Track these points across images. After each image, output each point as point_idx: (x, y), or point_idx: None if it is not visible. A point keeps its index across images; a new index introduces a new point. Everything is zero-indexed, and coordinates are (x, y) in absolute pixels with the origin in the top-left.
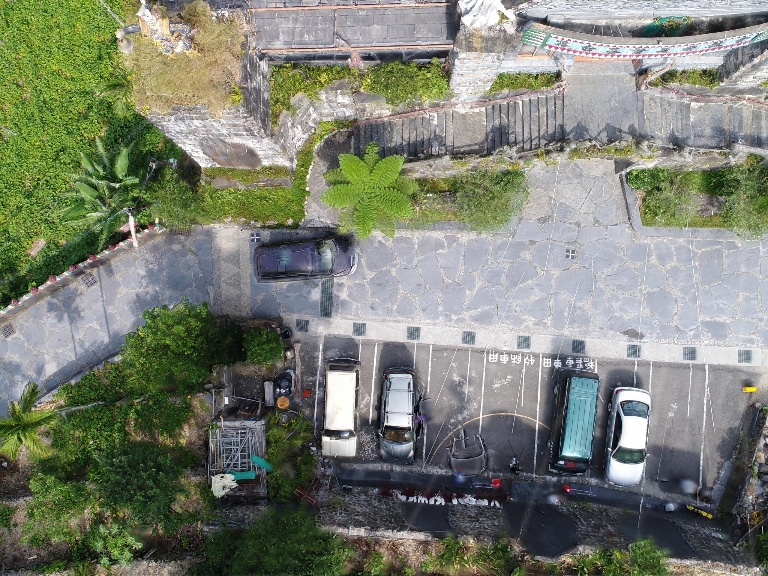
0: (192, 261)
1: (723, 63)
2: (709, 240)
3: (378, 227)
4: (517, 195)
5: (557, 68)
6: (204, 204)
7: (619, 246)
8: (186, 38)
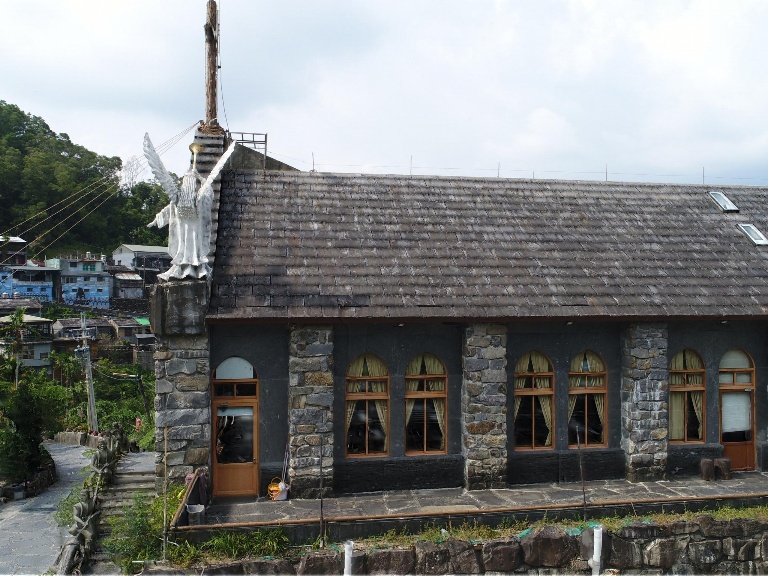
0: None
1: None
2: None
3: None
4: None
5: None
6: None
7: None
8: None
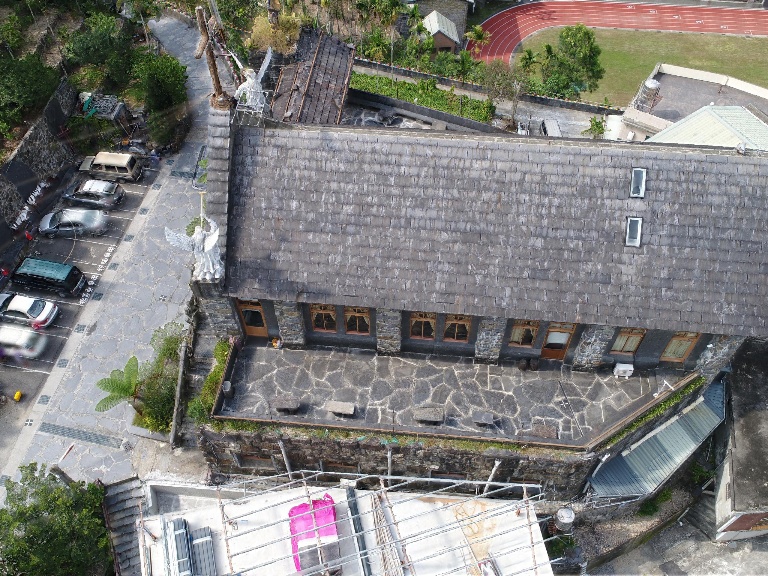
0: None
1: None
2: None
3: None
4: None
5: None
6: None
7: None
8: (272, 16)
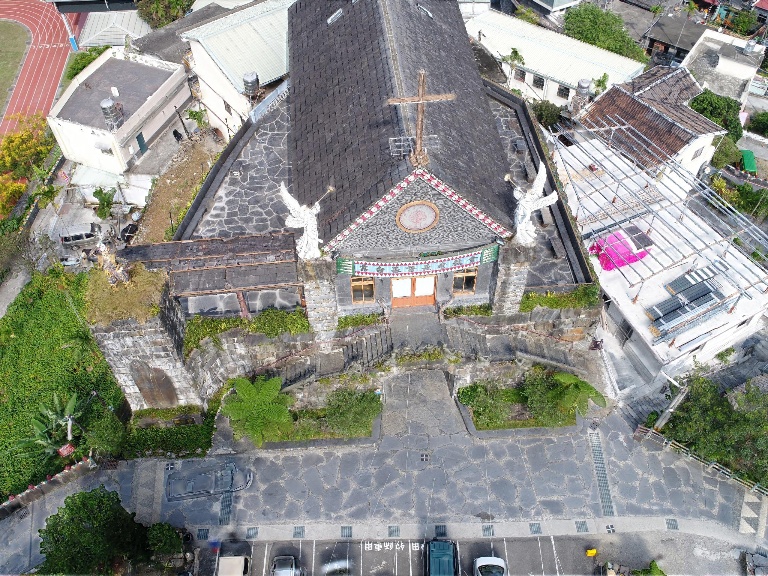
0: (115, 489)
1: (489, 297)
2: (531, 438)
3: (265, 434)
4: (371, 406)
5: (382, 309)
6: (130, 436)
7: (462, 449)
8: (126, 273)
